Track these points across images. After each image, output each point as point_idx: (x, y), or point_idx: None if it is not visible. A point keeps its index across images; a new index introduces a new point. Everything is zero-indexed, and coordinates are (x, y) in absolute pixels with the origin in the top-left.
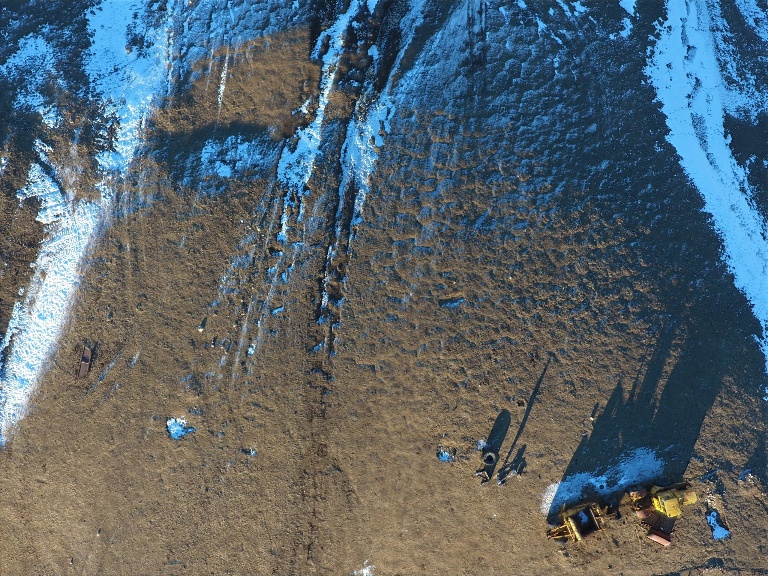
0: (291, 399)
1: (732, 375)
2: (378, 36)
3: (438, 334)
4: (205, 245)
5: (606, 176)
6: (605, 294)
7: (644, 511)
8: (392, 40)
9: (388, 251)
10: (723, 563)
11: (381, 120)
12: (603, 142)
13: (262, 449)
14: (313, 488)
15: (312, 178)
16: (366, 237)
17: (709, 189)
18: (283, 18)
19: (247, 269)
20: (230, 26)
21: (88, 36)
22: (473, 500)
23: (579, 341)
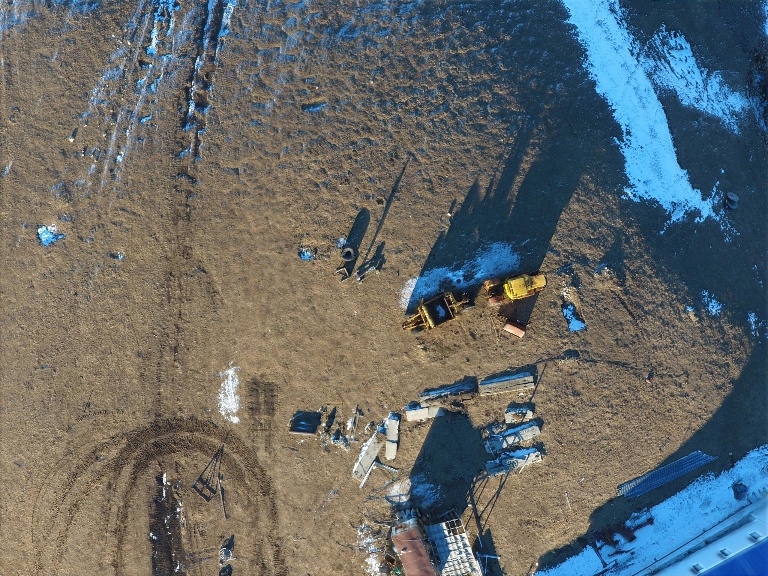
0: (157, 203)
1: (590, 173)
2: None
3: (300, 137)
4: (77, 59)
5: None
6: (464, 96)
7: (495, 297)
8: None
9: (253, 60)
10: (579, 355)
11: None
12: None
13: (129, 253)
14: (179, 290)
15: None
16: (232, 47)
17: (575, 4)
18: None
19: (117, 81)
20: None
21: None
22: (334, 298)
23: (438, 141)
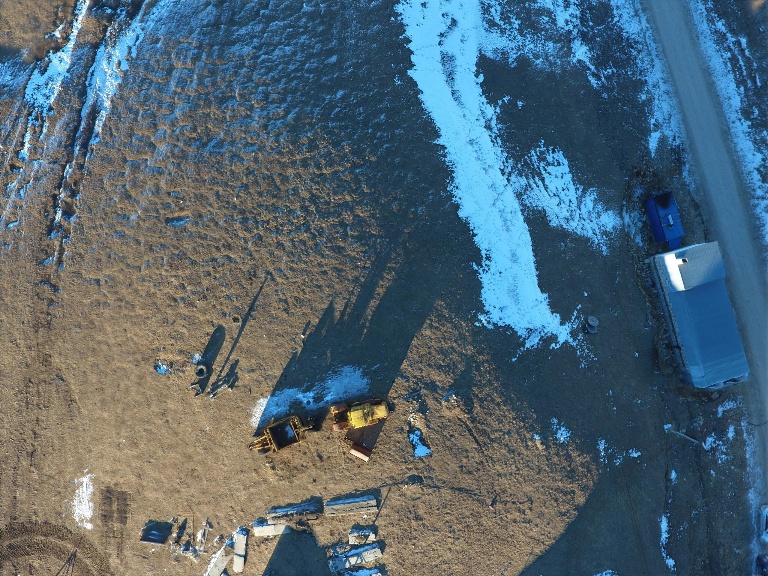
0: (19, 310)
1: (444, 300)
2: None
3: (162, 251)
4: None
5: (339, 105)
6: (325, 217)
7: (339, 424)
8: None
9: (121, 170)
10: (423, 480)
11: (129, 46)
12: (341, 73)
13: None
14: (37, 397)
15: (57, 99)
16: (101, 156)
17: (447, 123)
18: None
19: None
20: None
21: None
22: (187, 412)
23: (296, 261)
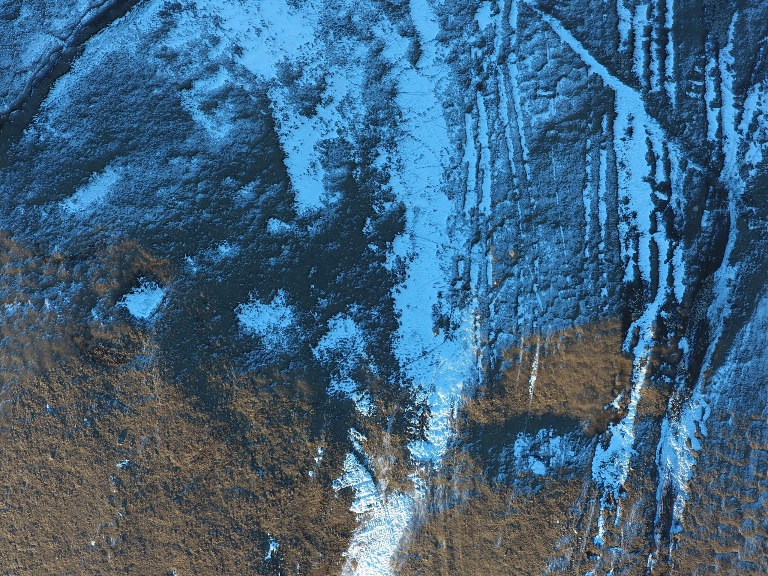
0: None
1: None
2: (687, 327)
3: None
4: (522, 546)
5: None
6: None
7: None
8: (701, 332)
9: (711, 564)
10: None
11: (696, 421)
12: None
13: None
14: None
15: (629, 481)
16: (688, 548)
17: None
18: (593, 308)
19: (565, 573)
20: (538, 312)
21: (395, 317)
22: None
23: None
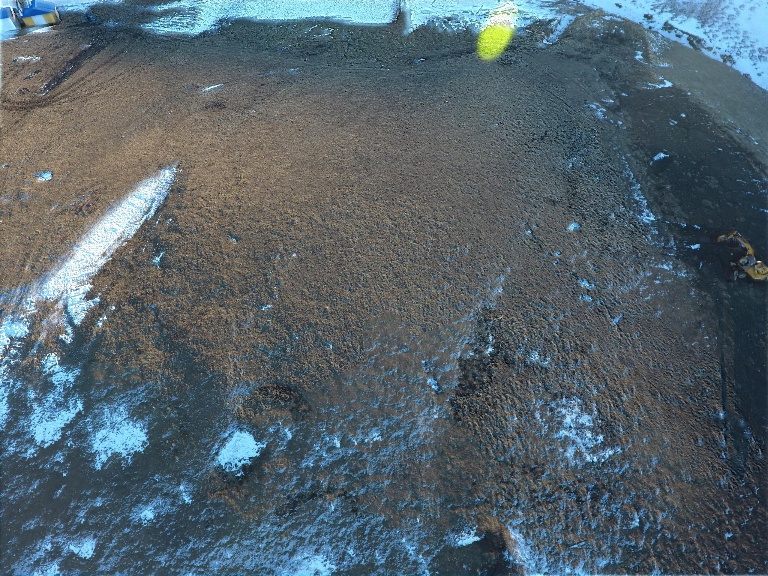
0: None
1: None
2: None
3: None
4: None
5: None
6: None
7: None
8: None
9: None
10: None
11: None
12: None
13: None
14: None
15: None
16: None
17: None
18: None
19: None
20: None
21: None
22: None
23: None
